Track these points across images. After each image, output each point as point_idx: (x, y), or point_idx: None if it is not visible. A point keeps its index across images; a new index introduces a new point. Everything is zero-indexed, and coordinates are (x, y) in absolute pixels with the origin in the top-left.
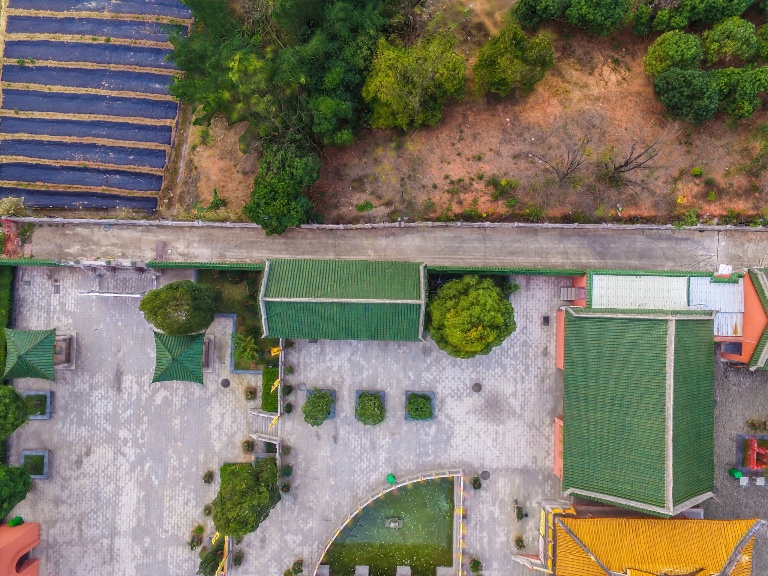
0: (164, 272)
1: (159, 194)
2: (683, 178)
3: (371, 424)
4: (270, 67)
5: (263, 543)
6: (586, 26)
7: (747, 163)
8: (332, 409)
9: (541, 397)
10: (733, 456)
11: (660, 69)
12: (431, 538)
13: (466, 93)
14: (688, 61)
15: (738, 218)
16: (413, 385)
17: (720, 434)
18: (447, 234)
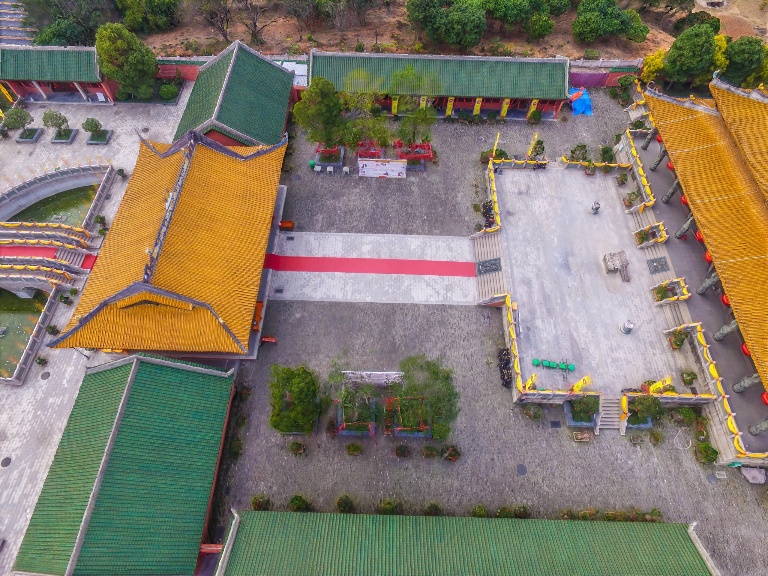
0: None
1: None
2: (302, 41)
3: (49, 122)
4: None
5: None
6: None
7: None
8: (36, 136)
9: None
10: (315, 159)
11: None
12: None
13: (183, 11)
14: None
15: None
16: (101, 128)
17: (307, 148)
18: None
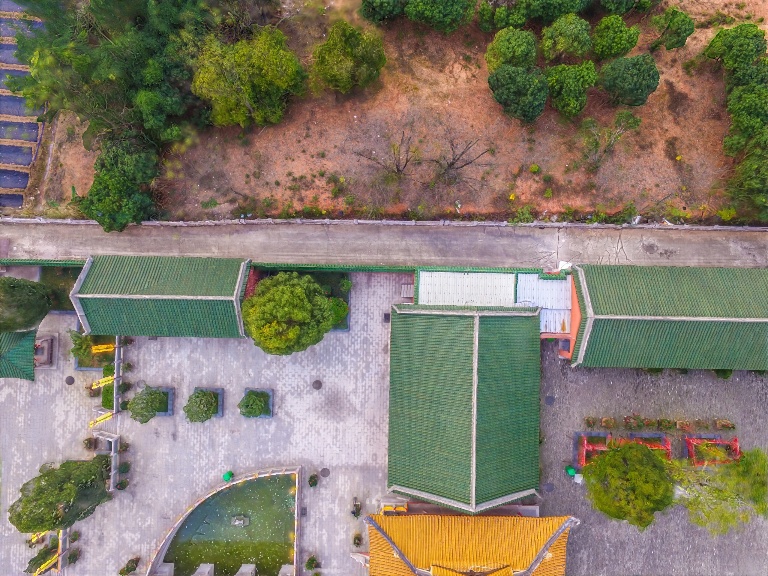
0: (9, 269)
1: (25, 191)
2: (522, 175)
3: None
4: (88, 63)
5: (101, 541)
6: (431, 23)
7: (587, 160)
8: (170, 406)
9: (381, 394)
10: (570, 453)
11: (496, 66)
12: (278, 536)
13: (306, 90)
14: (520, 58)
15: (577, 215)
16: (253, 382)
17: (557, 431)
18: (290, 231)
